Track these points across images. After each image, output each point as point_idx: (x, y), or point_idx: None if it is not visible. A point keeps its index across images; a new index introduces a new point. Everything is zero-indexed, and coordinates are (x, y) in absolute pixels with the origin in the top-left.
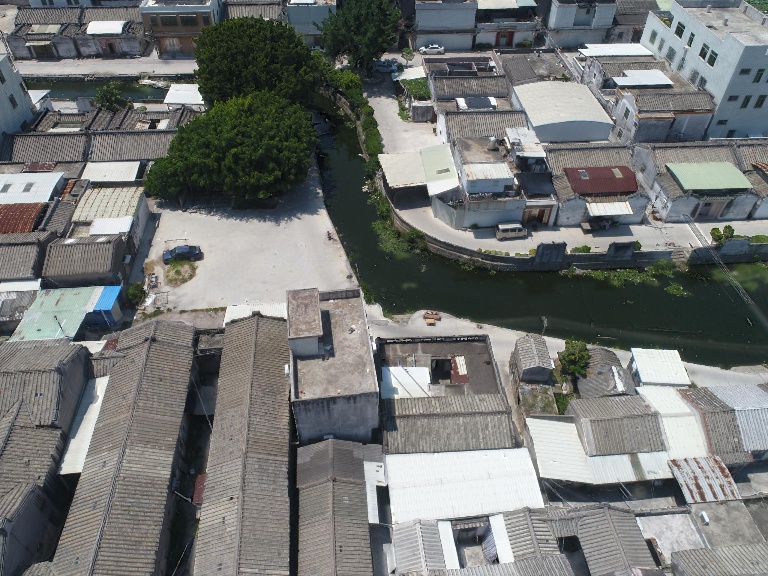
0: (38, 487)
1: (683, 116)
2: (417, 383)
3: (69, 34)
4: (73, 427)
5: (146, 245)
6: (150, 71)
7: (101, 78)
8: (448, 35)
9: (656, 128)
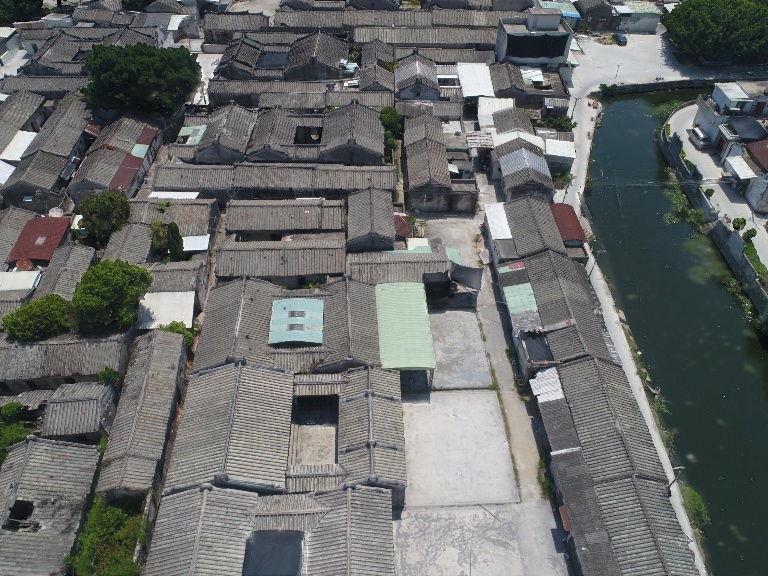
0: (468, 3)
1: None
2: (532, 77)
3: None
4: None
5: (625, 33)
6: None
7: None
8: None
9: None
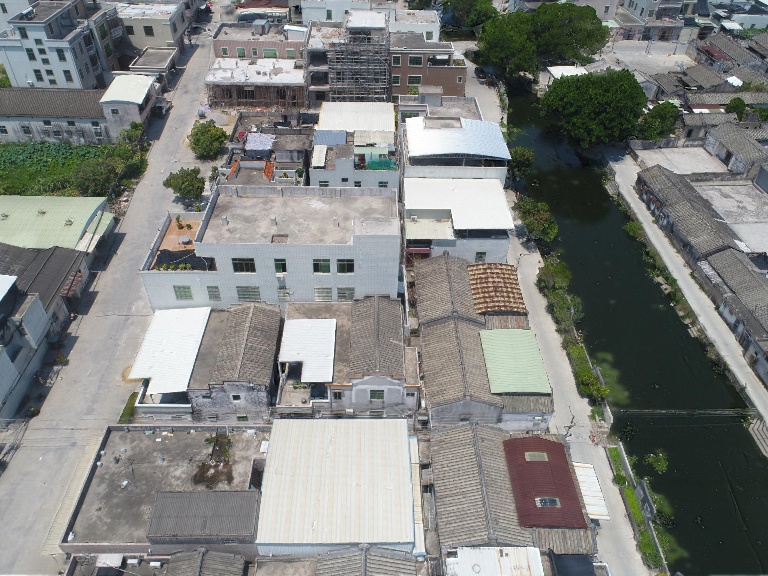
0: None
1: None
2: None
3: None
4: None
5: None
6: None
7: None
8: None
9: None
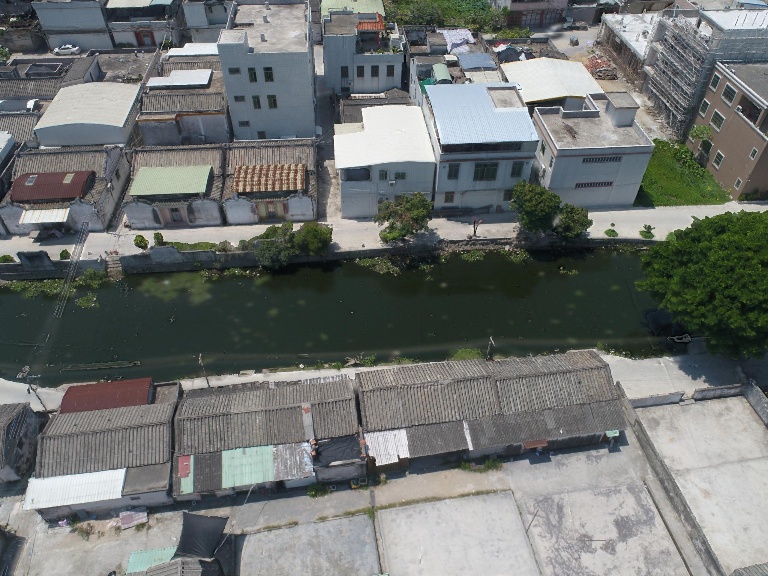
0: None
1: (193, 117)
2: None
3: None
4: None
5: None
6: None
7: None
8: (82, 35)
9: (162, 130)
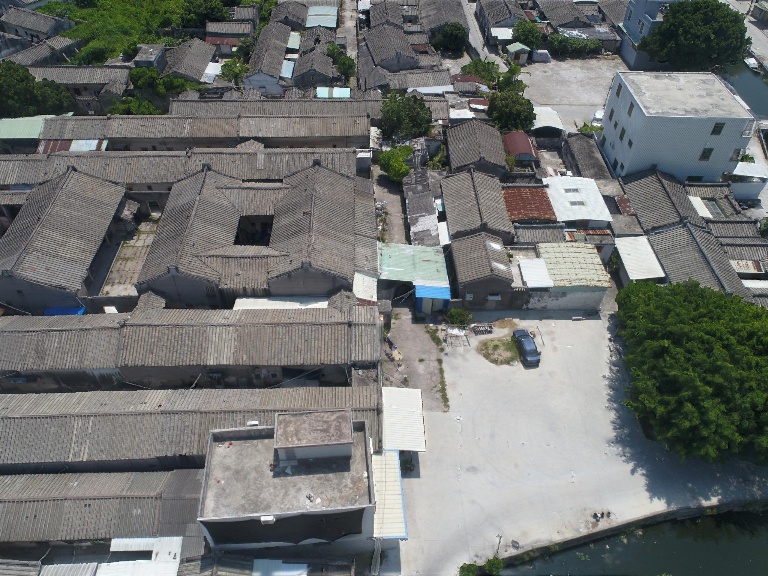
0: (216, 285)
1: None
2: None
3: None
4: (280, 297)
5: (541, 315)
6: None
7: None
8: None
9: None
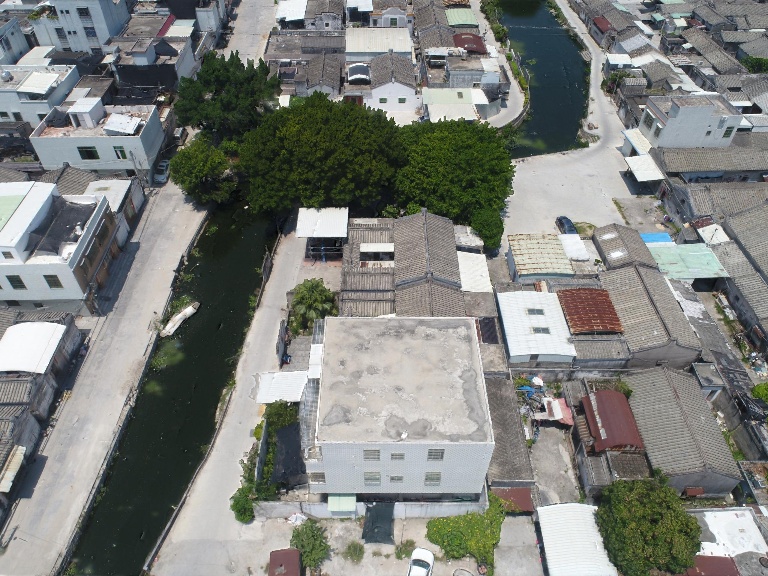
0: None
1: None
2: None
3: (11, 412)
4: None
5: None
6: (150, 318)
7: (140, 382)
8: None
9: None
